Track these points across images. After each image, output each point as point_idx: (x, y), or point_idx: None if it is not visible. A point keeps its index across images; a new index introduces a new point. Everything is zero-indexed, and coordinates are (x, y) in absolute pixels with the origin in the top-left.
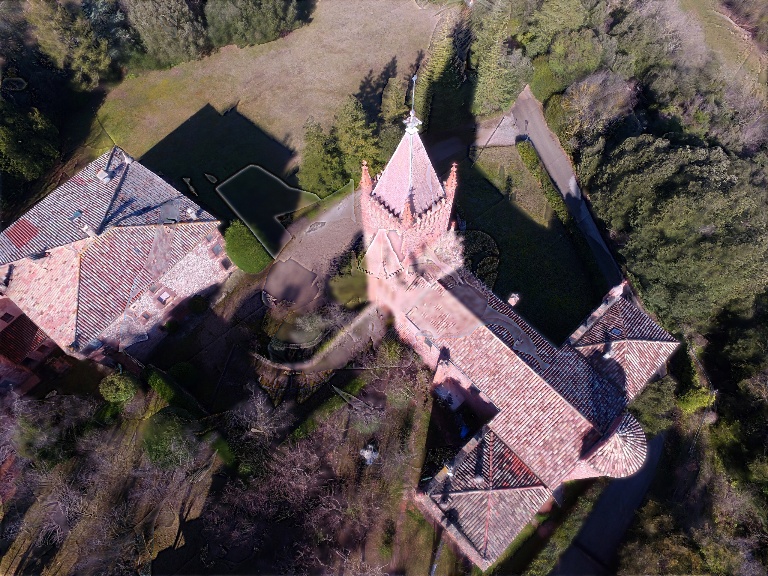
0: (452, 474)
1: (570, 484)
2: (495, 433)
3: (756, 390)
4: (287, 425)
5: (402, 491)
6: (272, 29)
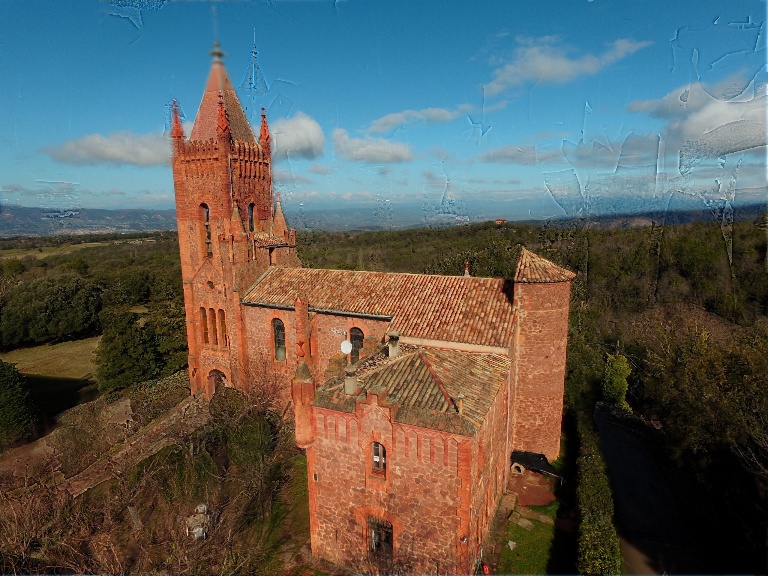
0: (349, 343)
1: (556, 465)
2: (399, 342)
3: (657, 365)
4: (3, 489)
5: (280, 557)
6: (81, 319)
